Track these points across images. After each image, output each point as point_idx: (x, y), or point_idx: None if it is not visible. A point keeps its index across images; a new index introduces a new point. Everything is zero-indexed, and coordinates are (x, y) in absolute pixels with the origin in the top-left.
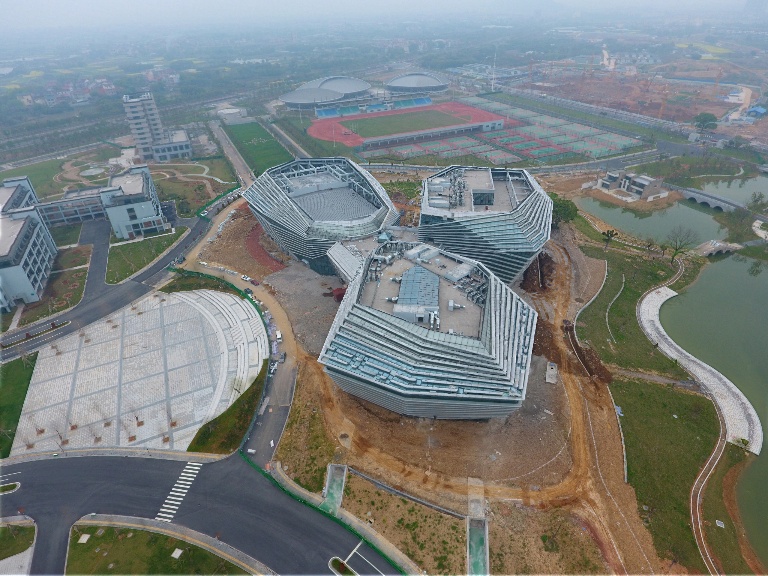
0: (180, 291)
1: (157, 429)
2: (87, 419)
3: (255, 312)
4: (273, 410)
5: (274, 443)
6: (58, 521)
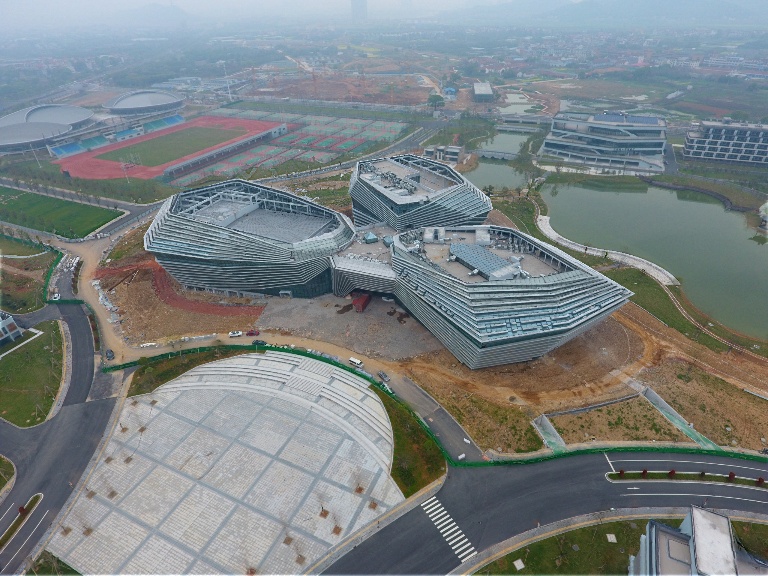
0: (165, 382)
1: (349, 505)
2: (254, 555)
3: (297, 356)
4: (433, 418)
5: (468, 440)
6: None
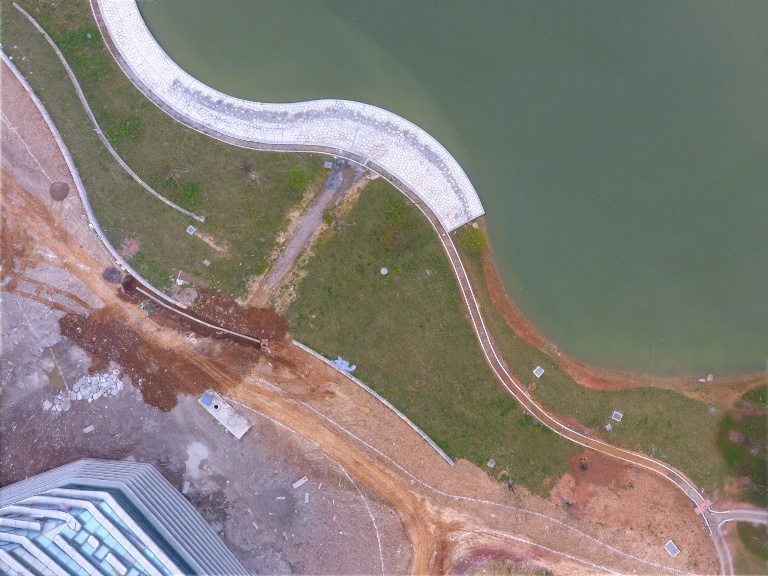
0: None
1: None
2: None
3: None
4: None
5: None
6: None
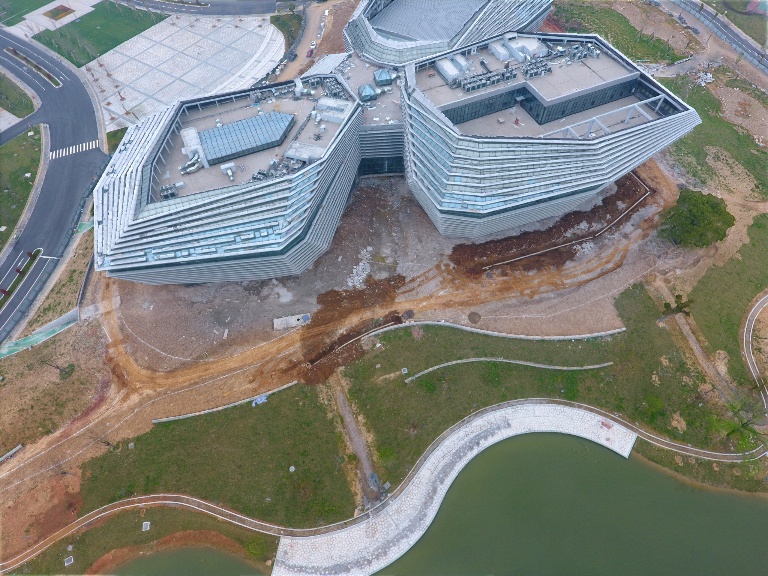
0: (275, 26)
1: (121, 109)
2: (118, 75)
3: None
4: None
5: None
6: (41, 117)
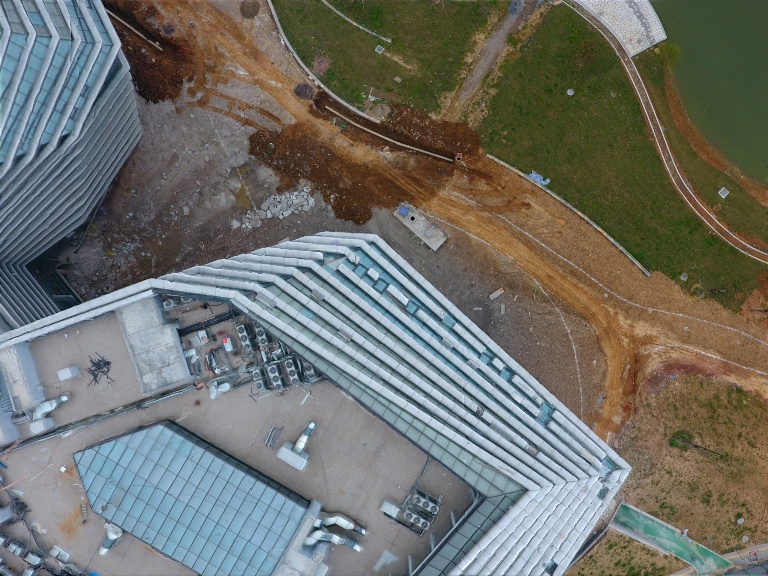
0: None
1: None
2: None
3: None
4: None
5: None
6: None
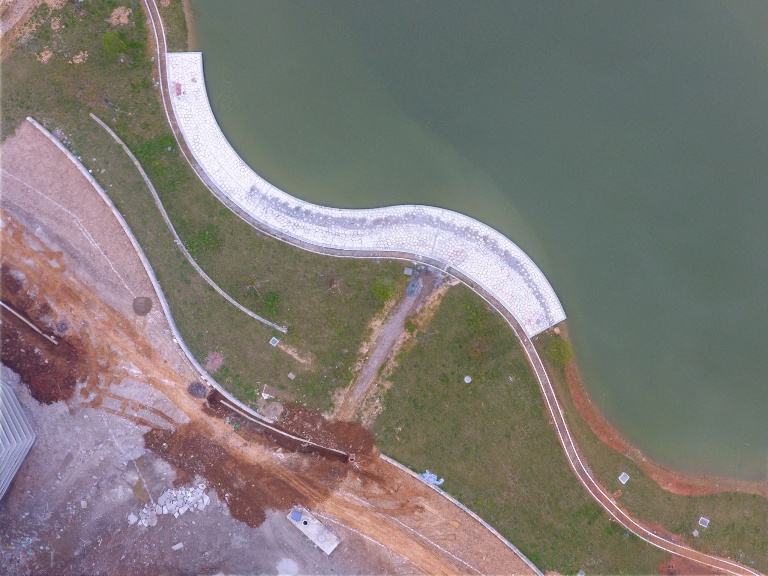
0: None
1: None
2: None
3: None
4: None
5: None
6: None
